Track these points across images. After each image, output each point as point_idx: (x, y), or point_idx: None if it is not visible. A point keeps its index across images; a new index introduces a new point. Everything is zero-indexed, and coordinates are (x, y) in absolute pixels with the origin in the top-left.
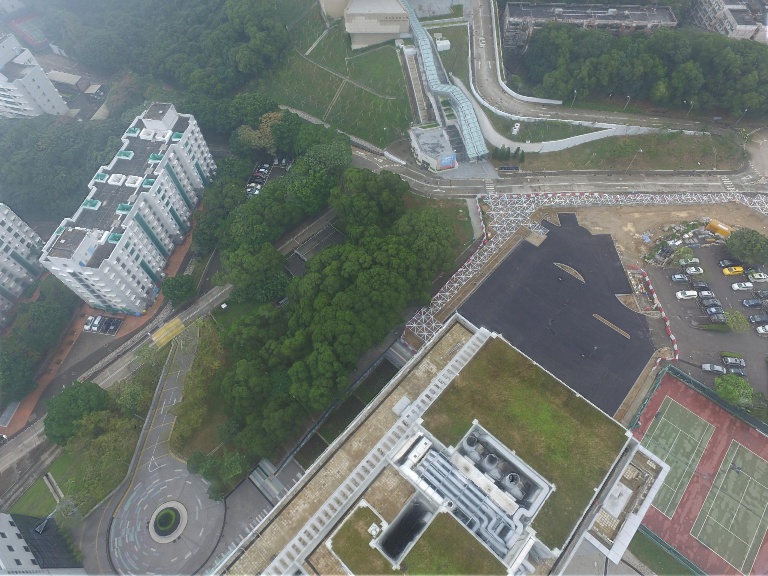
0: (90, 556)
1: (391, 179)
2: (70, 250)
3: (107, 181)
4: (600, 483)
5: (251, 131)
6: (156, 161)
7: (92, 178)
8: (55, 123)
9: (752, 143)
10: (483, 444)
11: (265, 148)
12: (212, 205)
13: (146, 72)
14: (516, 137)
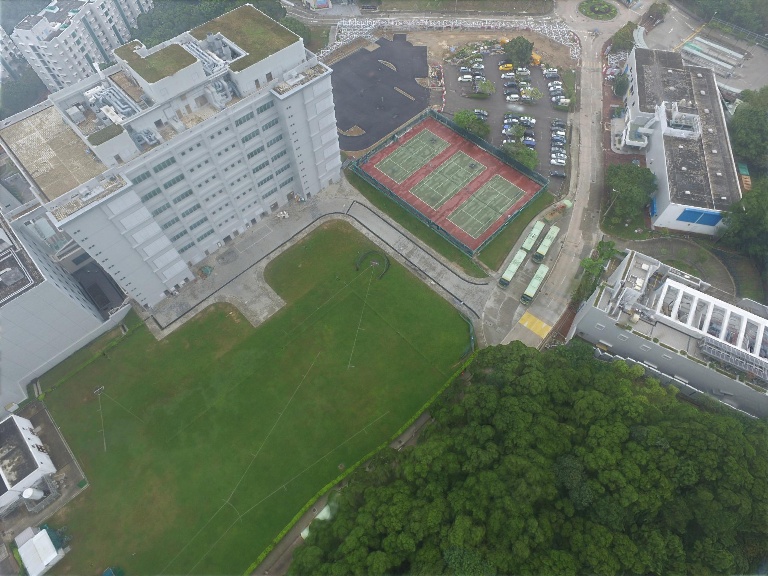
0: (27, 199)
1: (268, 0)
2: (31, 26)
3: None
4: (274, 53)
5: None
6: None
7: None
8: None
9: None
10: None
11: None
12: (143, 23)
13: None
14: None
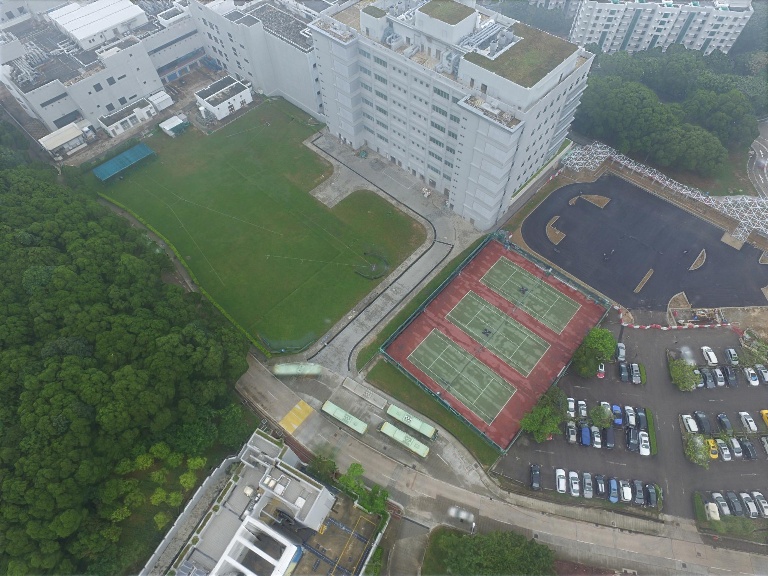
0: None
1: (745, 118)
2: None
3: None
4: (498, 75)
5: (764, 57)
6: (692, 5)
7: None
8: None
9: None
10: None
11: None
12: (669, 49)
13: None
14: None
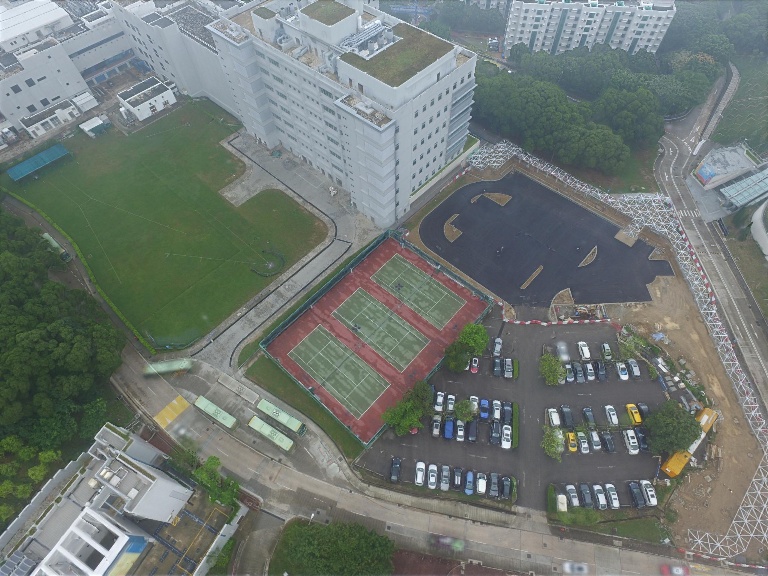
0: None
1: (649, 116)
2: None
3: None
4: (369, 74)
5: (686, 56)
6: (617, 4)
7: None
8: None
9: None
10: None
11: None
12: (593, 49)
13: (742, 6)
14: None
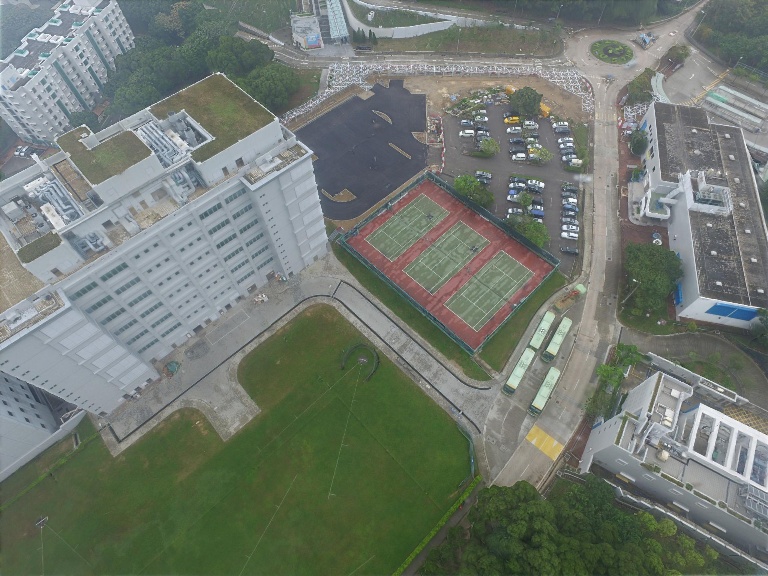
0: None
1: (254, 43)
2: None
3: (36, 38)
4: (244, 138)
5: (165, 17)
6: (77, 27)
7: (25, 36)
8: (13, 8)
9: (574, 38)
10: (187, 125)
11: (176, 31)
12: (120, 65)
13: None
14: (371, 23)
